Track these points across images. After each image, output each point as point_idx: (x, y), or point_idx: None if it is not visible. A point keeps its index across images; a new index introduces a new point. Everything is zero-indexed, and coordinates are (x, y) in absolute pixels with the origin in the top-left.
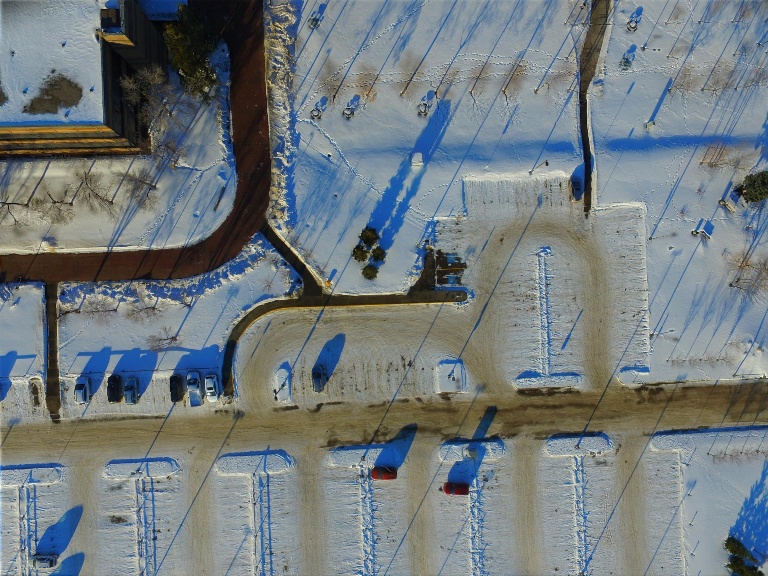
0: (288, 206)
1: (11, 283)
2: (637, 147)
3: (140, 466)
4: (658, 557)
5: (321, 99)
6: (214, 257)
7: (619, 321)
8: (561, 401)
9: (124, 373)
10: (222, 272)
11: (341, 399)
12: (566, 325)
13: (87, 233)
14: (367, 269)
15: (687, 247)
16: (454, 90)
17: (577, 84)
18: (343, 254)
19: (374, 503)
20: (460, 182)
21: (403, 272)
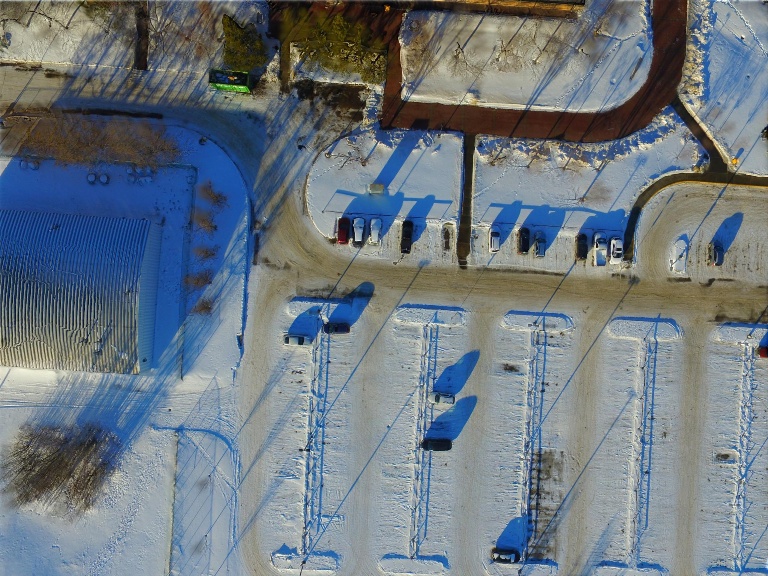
0: (704, 82)
1: (433, 130)
2: None
3: (537, 319)
4: None
5: None
6: (625, 125)
7: None
8: None
9: (533, 227)
10: (632, 140)
11: (733, 276)
12: None
13: (509, 89)
14: None
15: None
16: None
17: None
18: (752, 134)
19: (754, 382)
20: None
21: None
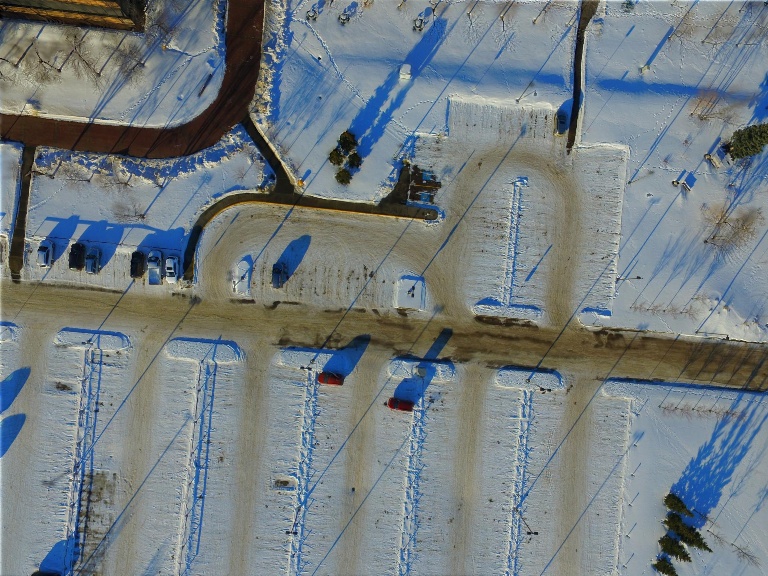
0: (271, 101)
1: None
2: (628, 90)
3: (92, 337)
4: (595, 503)
5: (319, 1)
6: (192, 142)
7: (587, 261)
8: (518, 333)
9: (88, 243)
10: (198, 158)
11: (298, 300)
12: (533, 258)
13: (71, 101)
14: (340, 172)
15: (666, 196)
16: (452, 10)
17: (576, 20)
18: (319, 156)
19: (317, 408)
20: (446, 101)
21: (377, 182)
